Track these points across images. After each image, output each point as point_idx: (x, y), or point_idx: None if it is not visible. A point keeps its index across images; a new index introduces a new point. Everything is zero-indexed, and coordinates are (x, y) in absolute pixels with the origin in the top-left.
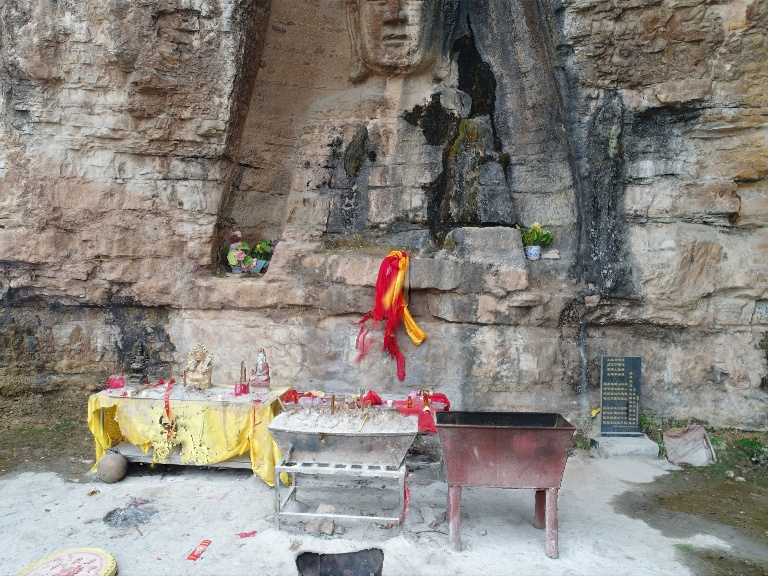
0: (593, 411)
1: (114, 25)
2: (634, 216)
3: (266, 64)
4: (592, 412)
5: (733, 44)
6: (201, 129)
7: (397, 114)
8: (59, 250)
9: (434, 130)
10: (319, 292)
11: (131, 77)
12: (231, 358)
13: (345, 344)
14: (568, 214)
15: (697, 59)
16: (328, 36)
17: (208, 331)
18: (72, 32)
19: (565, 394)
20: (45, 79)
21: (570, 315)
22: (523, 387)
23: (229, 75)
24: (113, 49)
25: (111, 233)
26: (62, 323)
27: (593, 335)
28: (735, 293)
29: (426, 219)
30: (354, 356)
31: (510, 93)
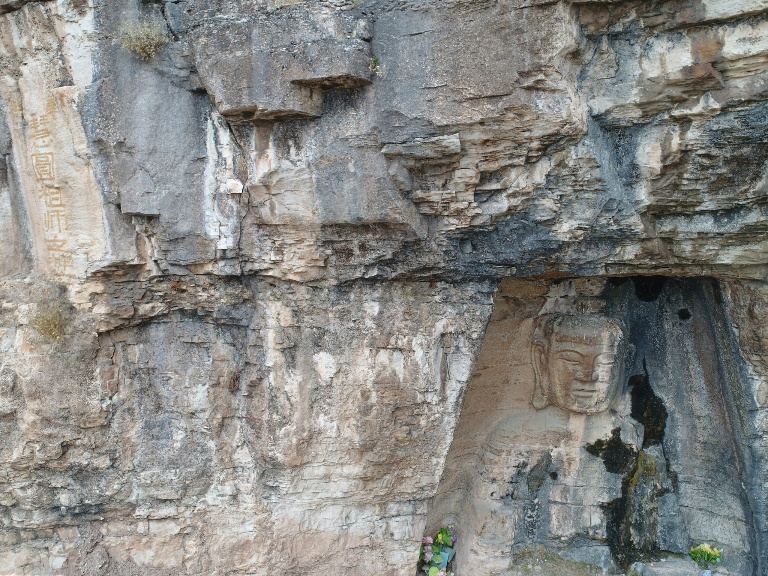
0: None
1: (360, 423)
2: None
3: None
4: None
5: None
6: (419, 483)
7: (580, 445)
8: None
9: (614, 461)
10: None
11: (368, 455)
12: None
13: None
14: (737, 540)
15: None
16: (514, 370)
17: None
18: (324, 431)
19: None
20: (296, 465)
21: None
22: None
23: (448, 442)
24: (358, 442)
25: (338, 574)
26: None
27: None
28: None
29: (605, 537)
30: None
31: (681, 426)
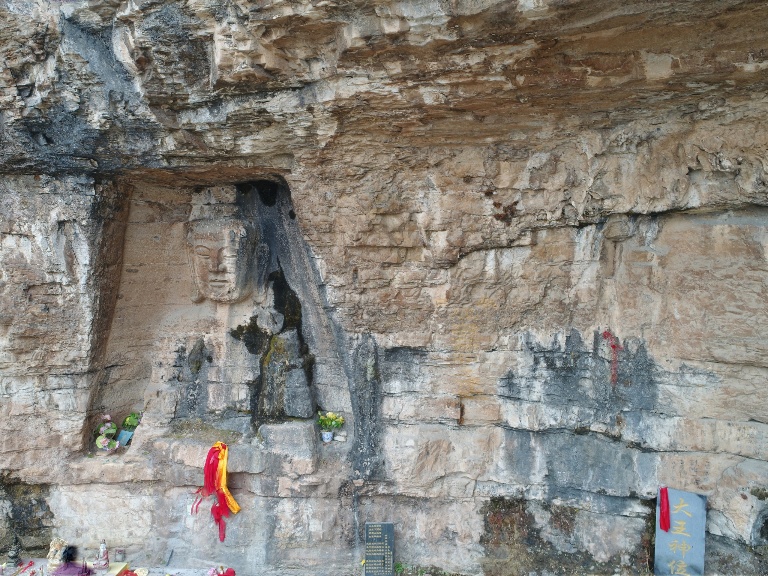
0: (363, 561)
1: None
2: (389, 420)
3: (123, 295)
4: (362, 562)
5: (441, 313)
6: (68, 357)
7: (225, 331)
8: None
9: (253, 343)
10: (165, 469)
11: (10, 329)
12: (97, 523)
13: (184, 510)
14: None
15: (419, 320)
16: (174, 269)
17: (79, 502)
18: None
19: (343, 548)
20: None
21: (346, 491)
22: (312, 544)
23: (87, 320)
24: None
25: (0, 436)
26: None
27: (365, 503)
28: (461, 474)
29: (249, 409)
30: (190, 521)
31: (311, 314)
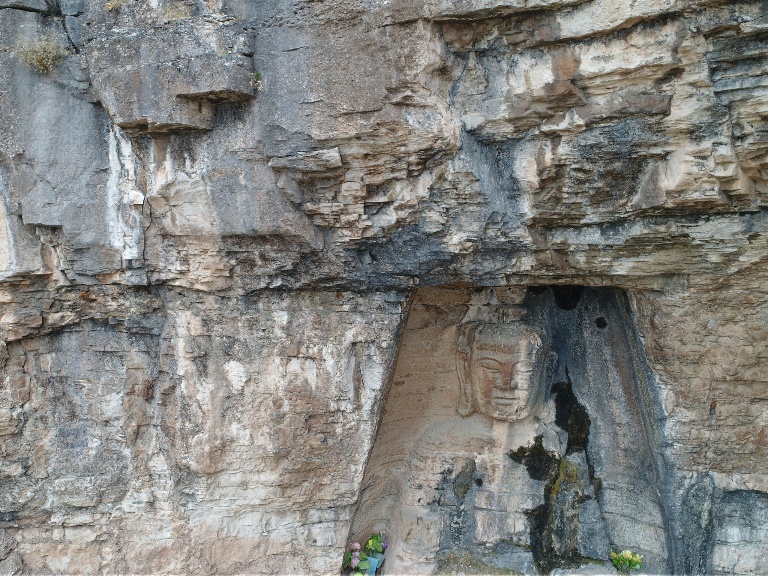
0: None
1: (273, 431)
2: (722, 573)
3: (387, 411)
4: None
5: None
6: (338, 490)
7: (503, 452)
8: None
9: (537, 468)
10: None
11: (283, 463)
12: None
13: None
14: (657, 547)
15: None
16: (439, 377)
17: None
18: (237, 439)
19: None
20: None
21: None
22: None
23: (365, 450)
24: (272, 450)
25: None
26: None
27: None
28: None
29: (529, 544)
30: None
31: (603, 433)
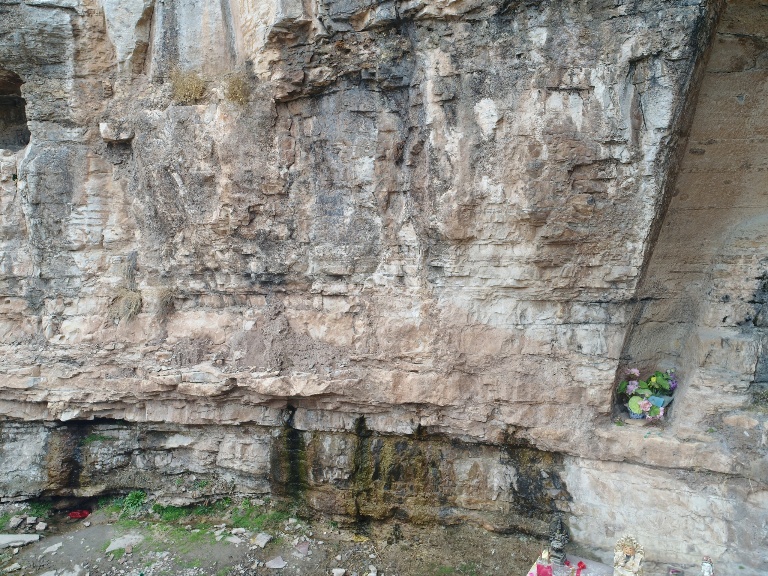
0: None
1: (529, 185)
2: None
3: (679, 191)
4: None
5: None
6: (610, 276)
7: None
8: (463, 393)
9: None
10: (749, 459)
11: (541, 231)
12: (637, 521)
13: None
14: None
15: None
16: (758, 148)
17: (609, 486)
18: (488, 195)
19: None
20: (460, 239)
21: None
22: None
23: (647, 219)
24: (527, 208)
25: (512, 379)
26: (462, 459)
27: None
28: None
29: None
30: None
31: None
